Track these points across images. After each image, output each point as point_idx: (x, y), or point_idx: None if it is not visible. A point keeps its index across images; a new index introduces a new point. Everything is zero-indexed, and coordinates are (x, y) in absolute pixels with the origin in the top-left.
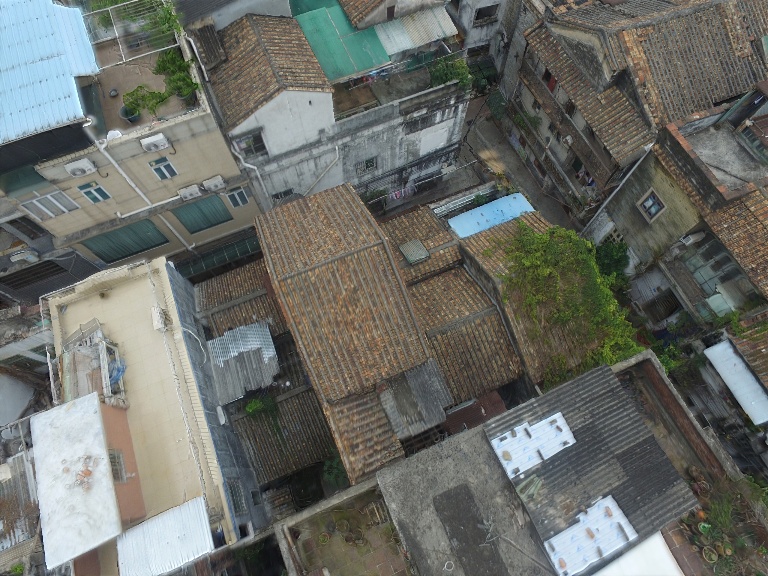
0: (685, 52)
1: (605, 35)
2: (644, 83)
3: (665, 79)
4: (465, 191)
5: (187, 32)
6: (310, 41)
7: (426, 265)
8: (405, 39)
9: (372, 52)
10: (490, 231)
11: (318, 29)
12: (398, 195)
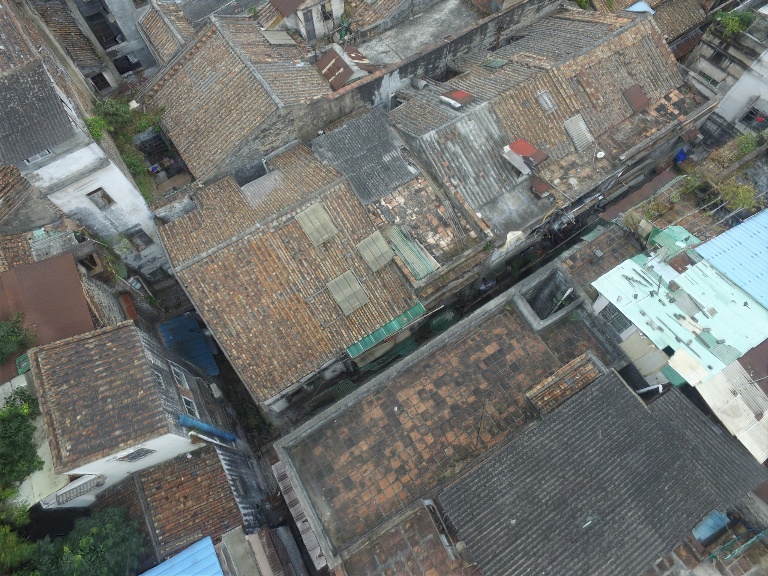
0: None
1: None
2: None
3: None
4: None
5: None
6: None
7: None
8: None
9: None
10: (627, 2)
11: None
12: None
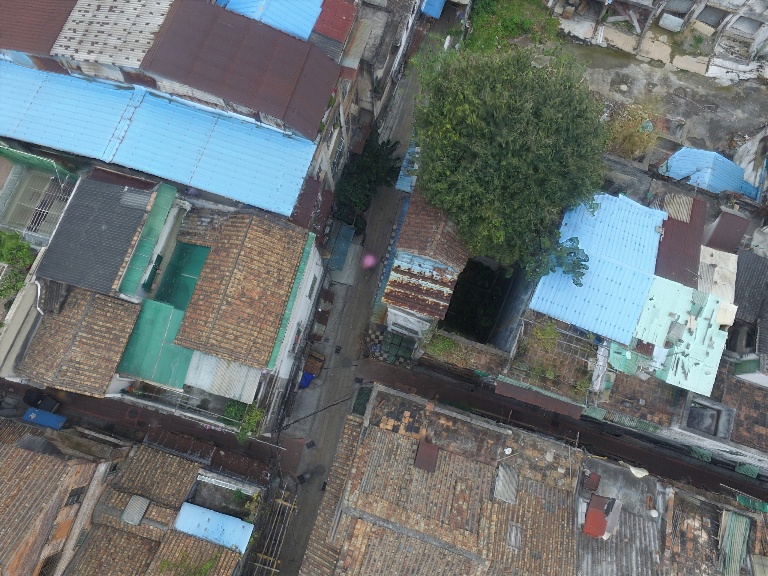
0: (408, 569)
1: (338, 512)
2: (347, 567)
3: (372, 575)
4: (234, 479)
5: (40, 279)
6: (140, 328)
7: (134, 527)
8: (208, 379)
9: (175, 371)
10: (193, 543)
11: (154, 322)
12: (208, 427)
